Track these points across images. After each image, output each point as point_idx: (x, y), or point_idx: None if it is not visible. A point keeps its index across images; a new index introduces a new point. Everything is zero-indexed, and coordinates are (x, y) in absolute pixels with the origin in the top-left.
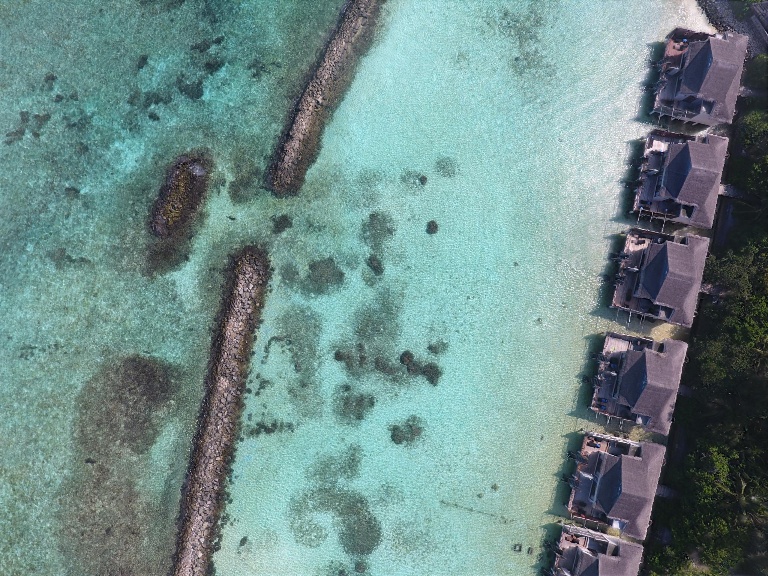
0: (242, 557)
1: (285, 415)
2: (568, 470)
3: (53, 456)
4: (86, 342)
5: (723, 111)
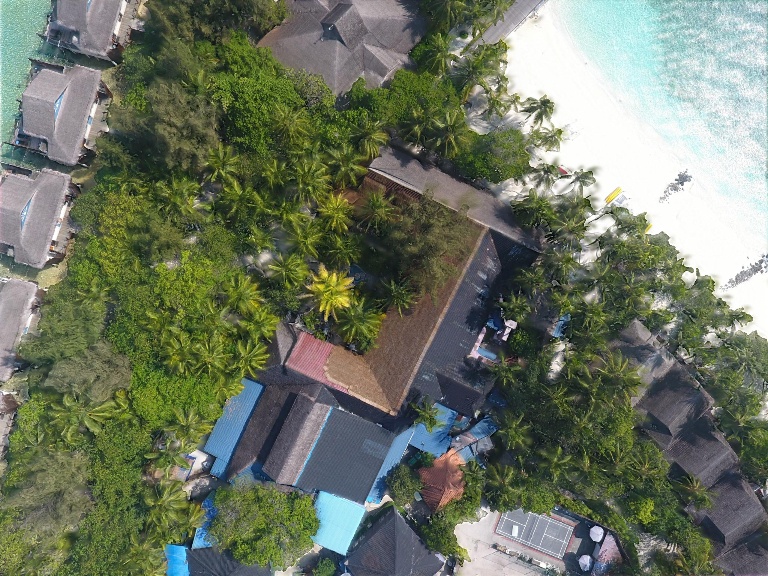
0: None
1: None
2: None
3: None
4: None
5: (90, 41)
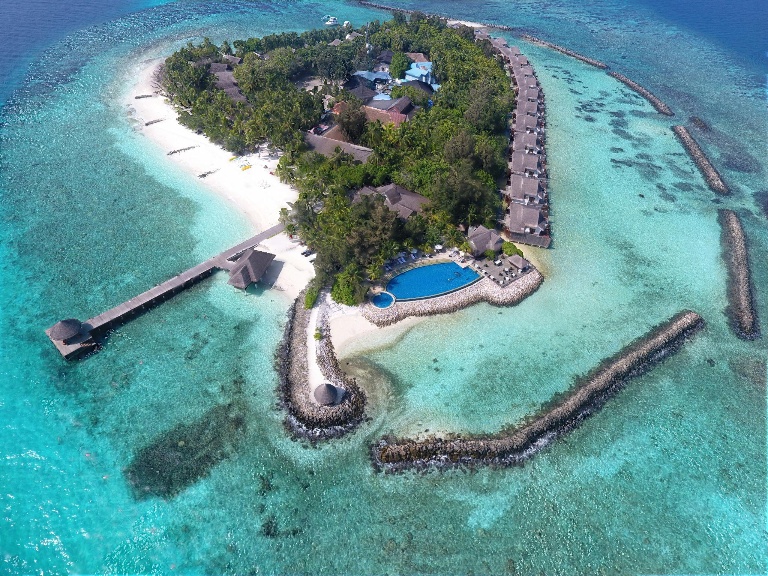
0: None
1: None
2: None
3: None
4: None
5: None
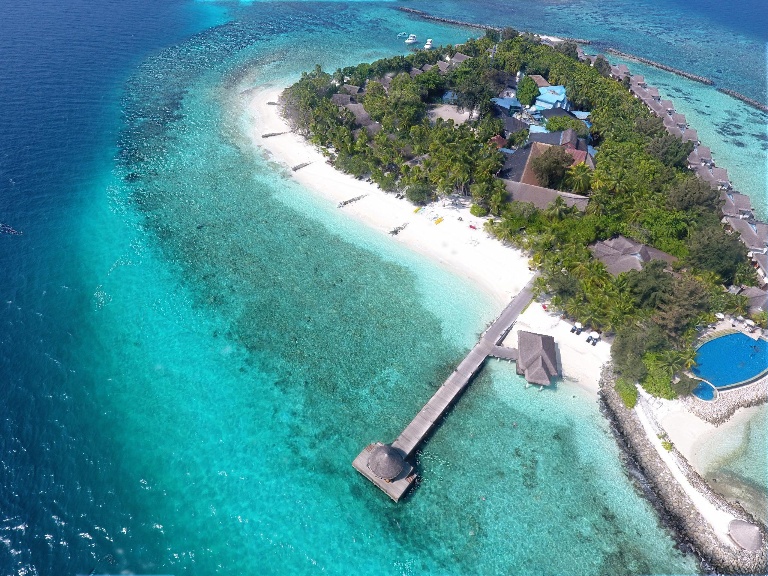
0: None
1: None
2: None
3: None
4: None
5: None
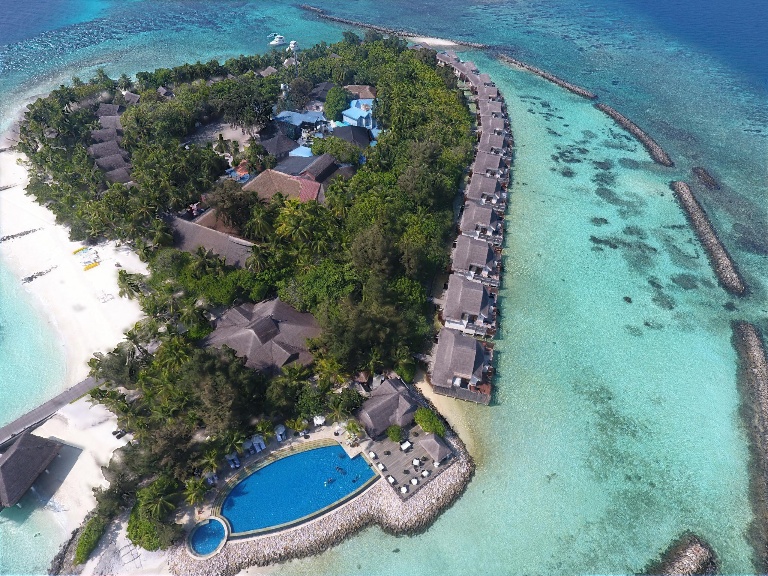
0: (660, 191)
1: (670, 231)
2: None
3: None
4: None
5: None
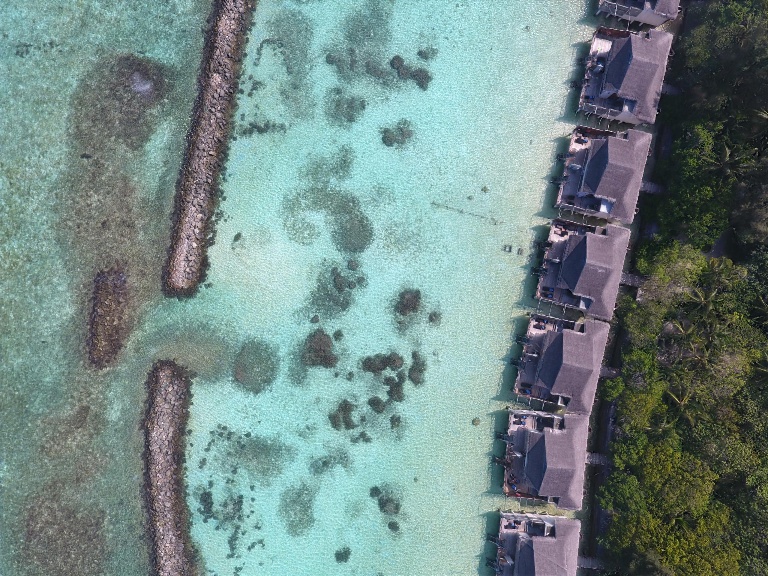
0: (236, 252)
1: (277, 116)
2: (557, 173)
3: (49, 151)
4: (81, 41)
5: None
